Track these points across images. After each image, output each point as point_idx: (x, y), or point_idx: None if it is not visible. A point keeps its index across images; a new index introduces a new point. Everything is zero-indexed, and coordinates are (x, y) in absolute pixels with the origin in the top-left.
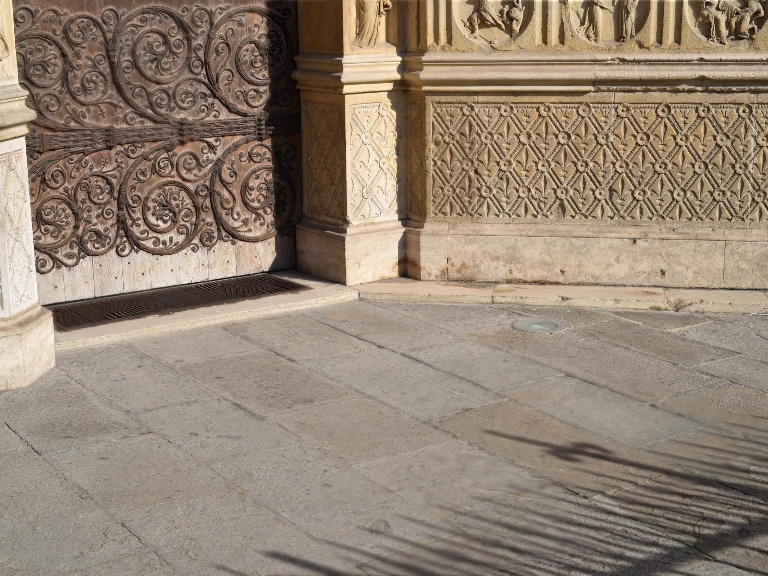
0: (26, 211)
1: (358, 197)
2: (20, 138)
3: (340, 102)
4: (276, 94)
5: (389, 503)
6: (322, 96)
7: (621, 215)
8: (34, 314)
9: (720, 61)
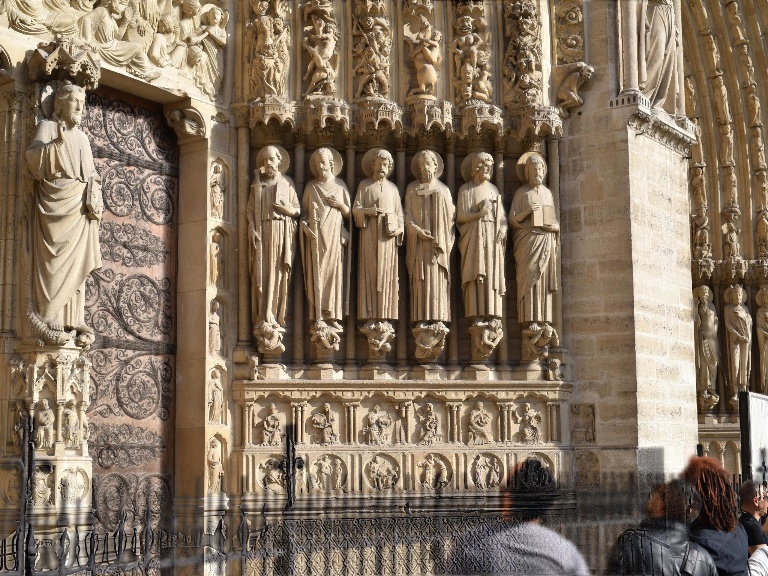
0: None
1: (209, 569)
2: None
3: (201, 520)
4: (163, 518)
5: None
6: (190, 518)
7: (339, 574)
8: None
9: (380, 498)
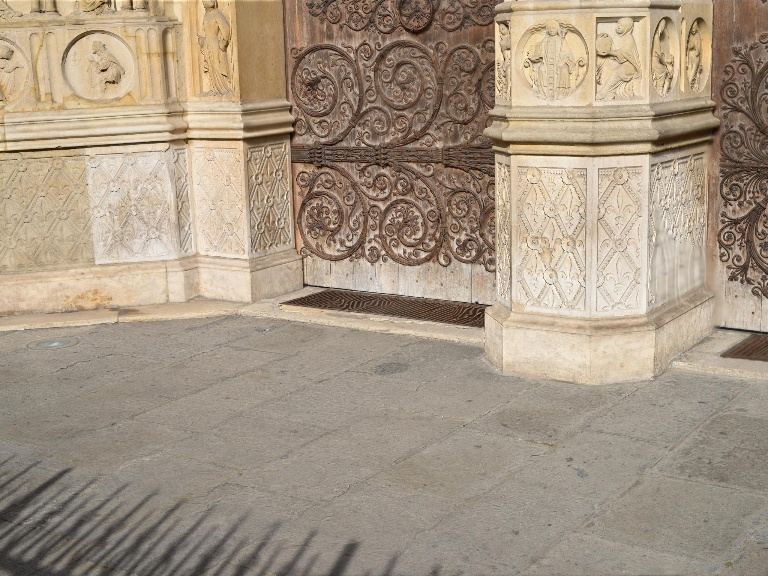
0: (640, 225)
1: None
2: (638, 156)
3: None
4: None
5: (505, 567)
6: None
7: None
8: (631, 324)
9: None
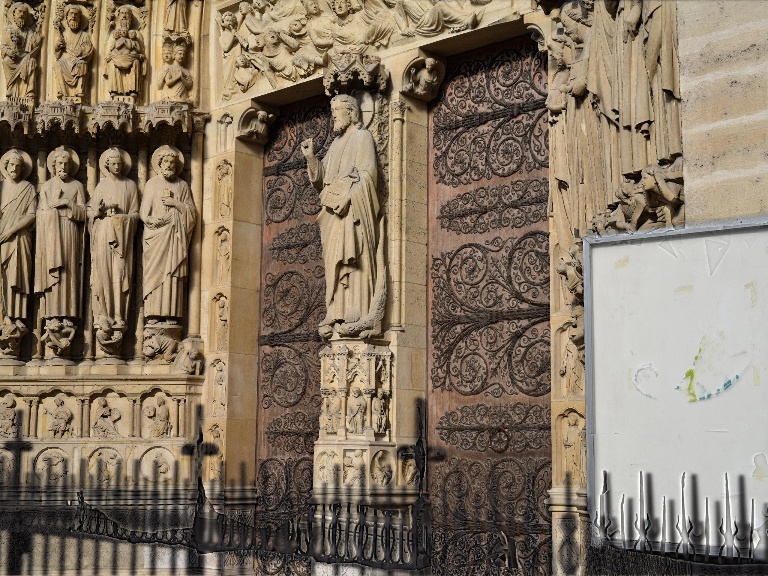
0: None
1: None
2: None
3: None
4: None
5: None
6: None
7: None
8: None
9: None
